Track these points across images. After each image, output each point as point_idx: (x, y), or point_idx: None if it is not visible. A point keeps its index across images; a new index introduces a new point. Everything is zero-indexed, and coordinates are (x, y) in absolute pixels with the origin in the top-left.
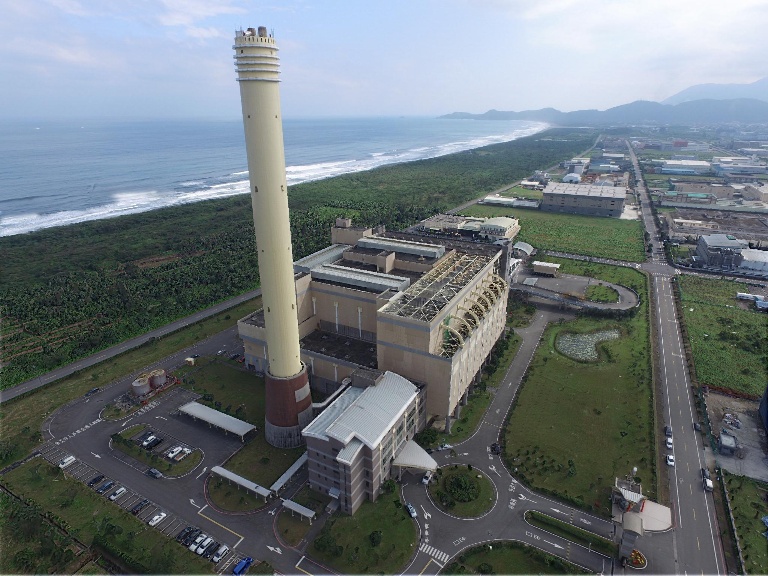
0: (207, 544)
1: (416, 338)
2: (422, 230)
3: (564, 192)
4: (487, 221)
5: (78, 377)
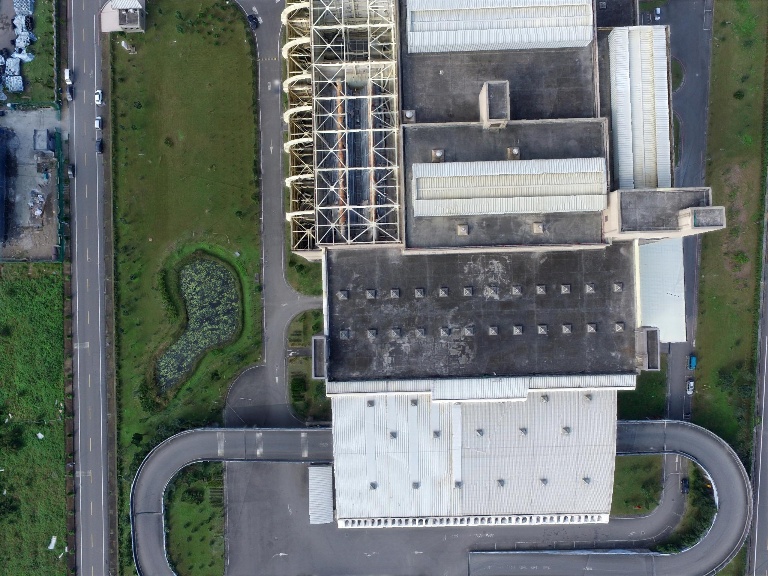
0: None
1: None
2: None
3: None
4: None
5: None
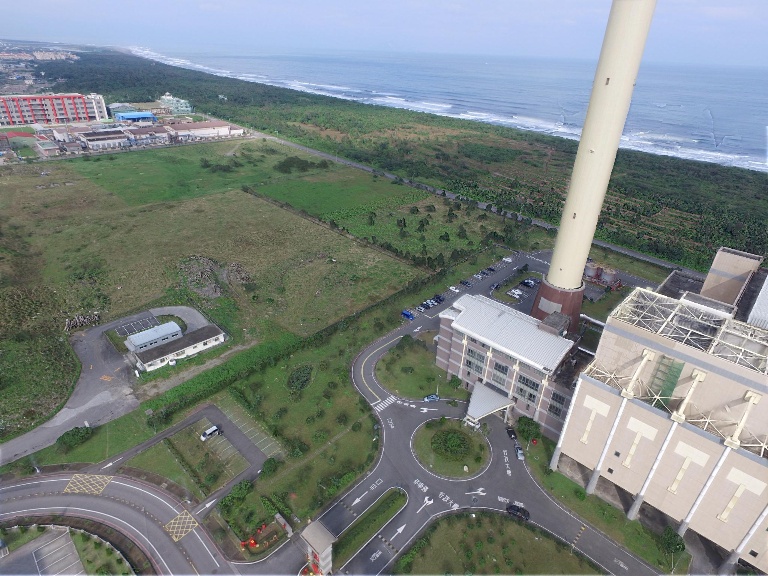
0: (428, 303)
1: None
2: None
3: None
4: None
5: (606, 252)
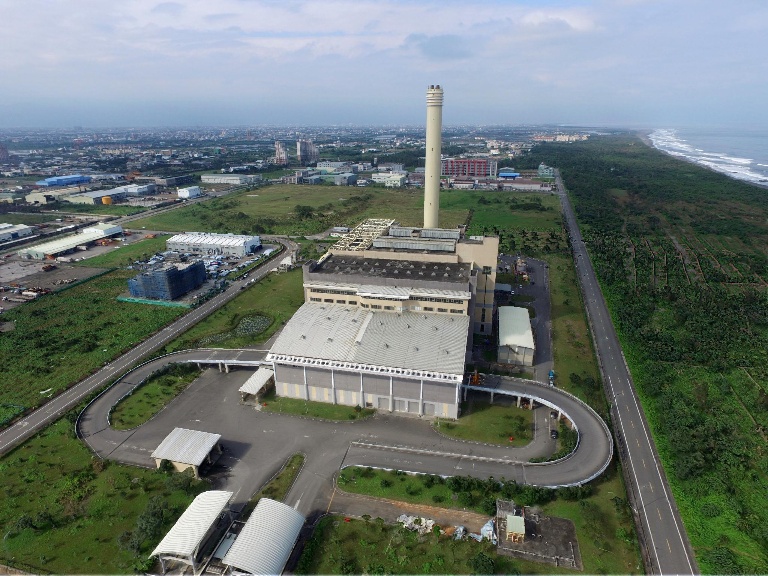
0: None
1: None
2: None
3: None
4: None
5: None
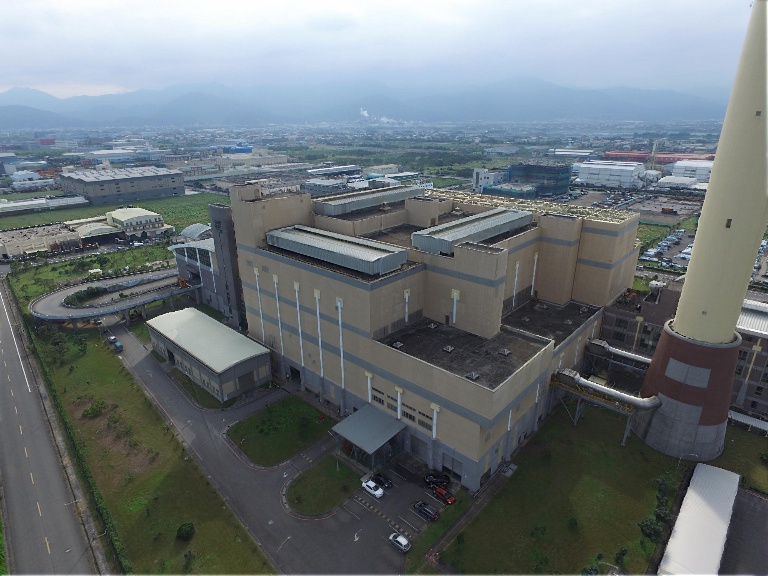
0: None
1: (631, 238)
2: (15, 259)
3: (113, 177)
4: (117, 216)
5: None
